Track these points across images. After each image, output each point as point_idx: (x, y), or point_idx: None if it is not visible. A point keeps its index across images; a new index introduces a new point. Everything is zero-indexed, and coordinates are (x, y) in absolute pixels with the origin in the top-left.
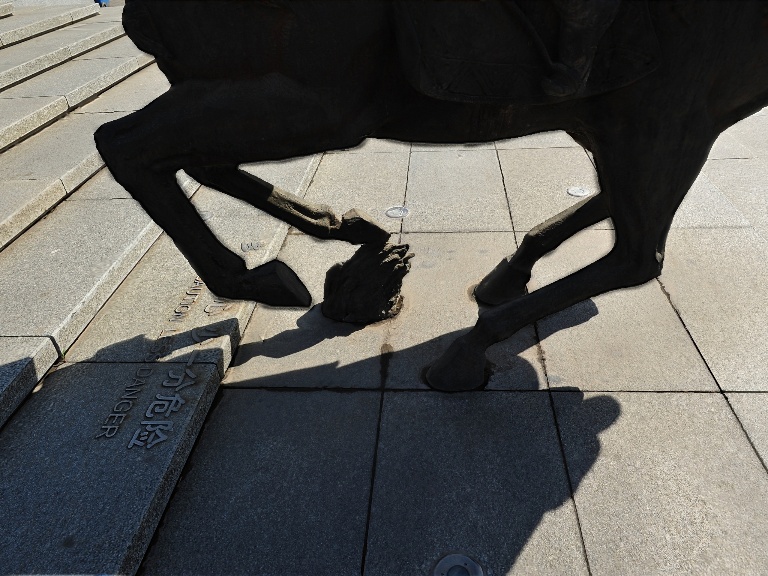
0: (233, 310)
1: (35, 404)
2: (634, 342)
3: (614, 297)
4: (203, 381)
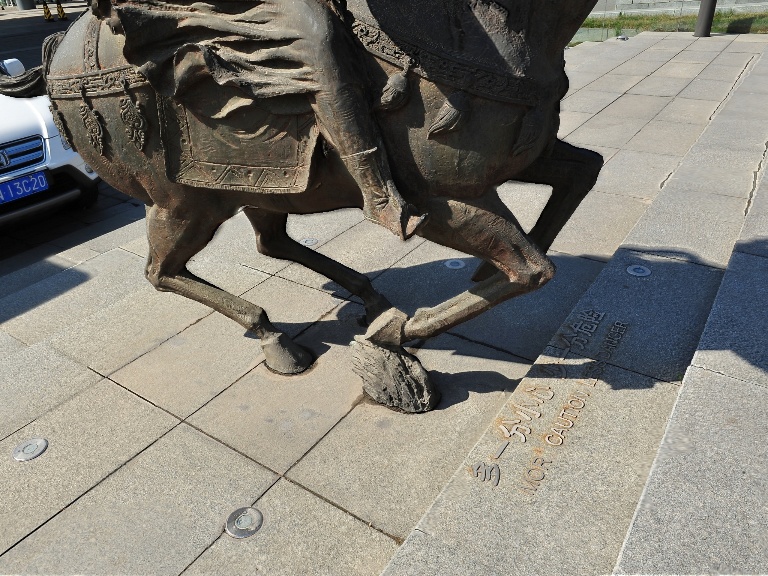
0: (526, 385)
1: (688, 358)
2: (269, 304)
3: (230, 329)
4: (557, 335)
